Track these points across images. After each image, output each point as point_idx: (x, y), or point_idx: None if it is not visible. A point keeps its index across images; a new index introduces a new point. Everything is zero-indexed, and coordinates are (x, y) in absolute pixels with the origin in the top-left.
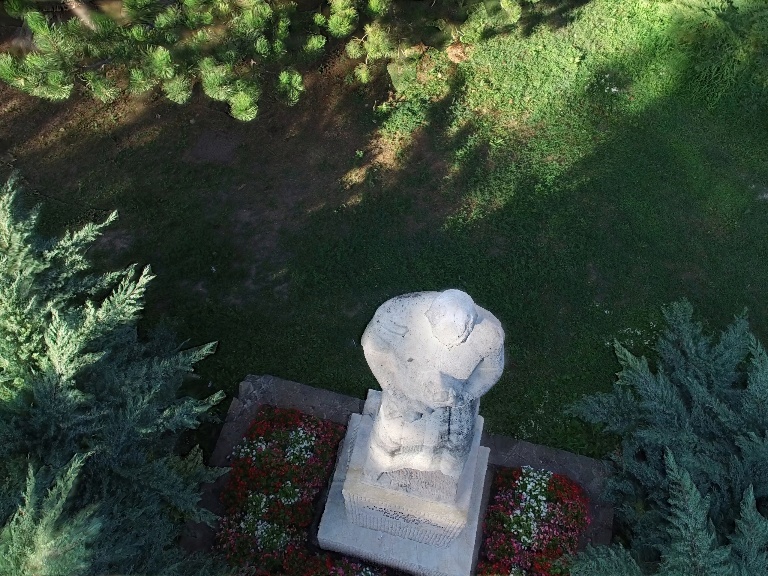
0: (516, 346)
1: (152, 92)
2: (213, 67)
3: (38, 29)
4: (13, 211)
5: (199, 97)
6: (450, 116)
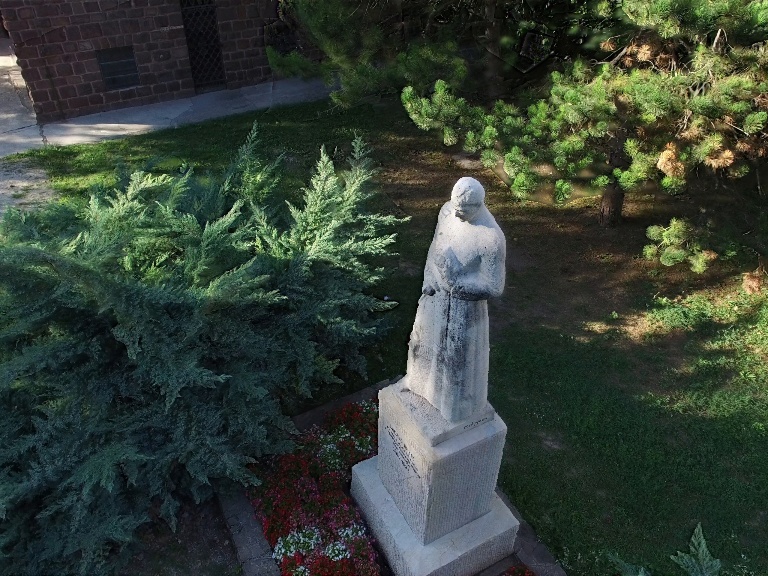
0: (624, 510)
1: (506, 213)
2: (517, 153)
3: (438, 89)
4: (363, 185)
5: (500, 171)
6: (718, 335)
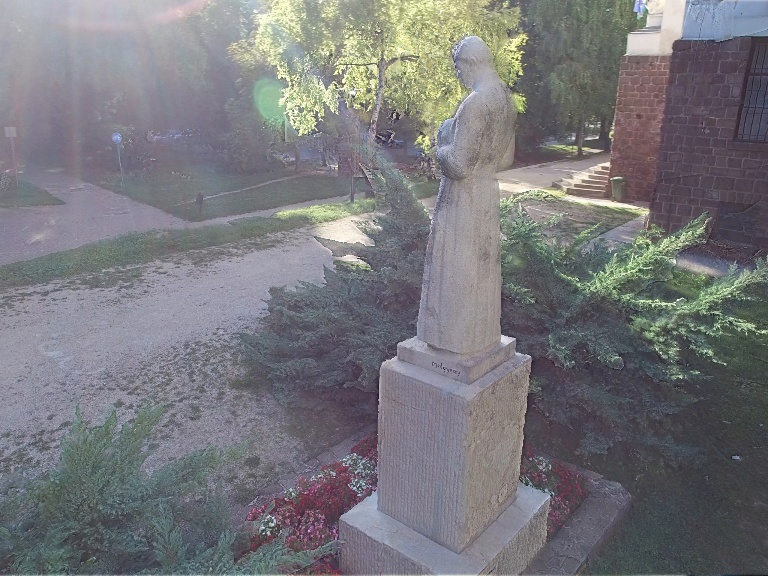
0: None
1: None
2: None
3: None
4: (750, 287)
5: None
6: None
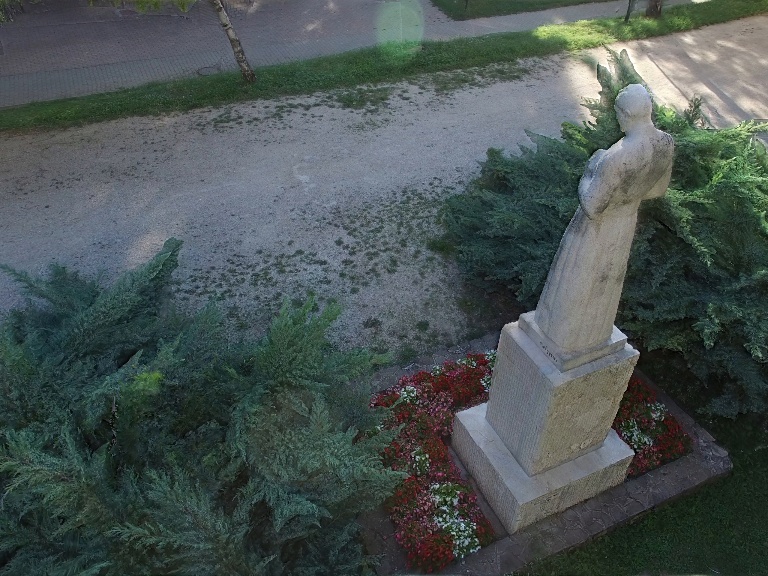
0: None
1: None
2: None
3: None
4: None
5: None
6: None
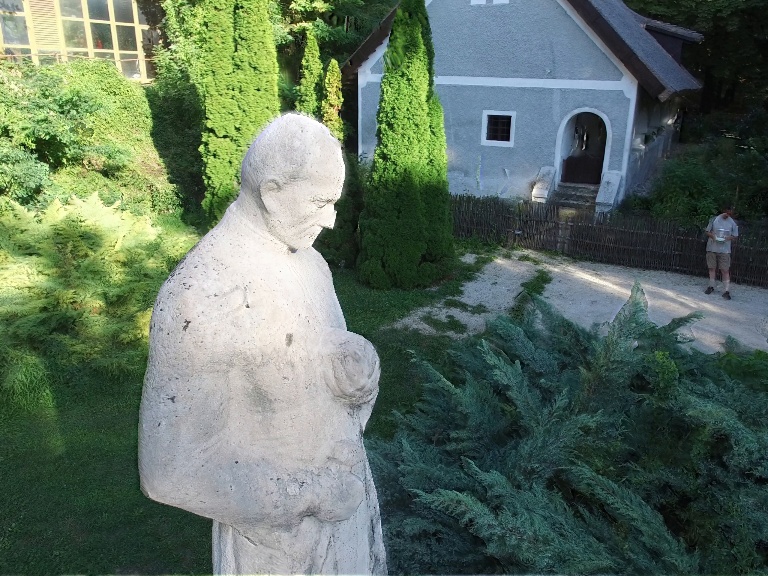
0: None
1: None
2: None
3: None
4: None
5: None
6: None
